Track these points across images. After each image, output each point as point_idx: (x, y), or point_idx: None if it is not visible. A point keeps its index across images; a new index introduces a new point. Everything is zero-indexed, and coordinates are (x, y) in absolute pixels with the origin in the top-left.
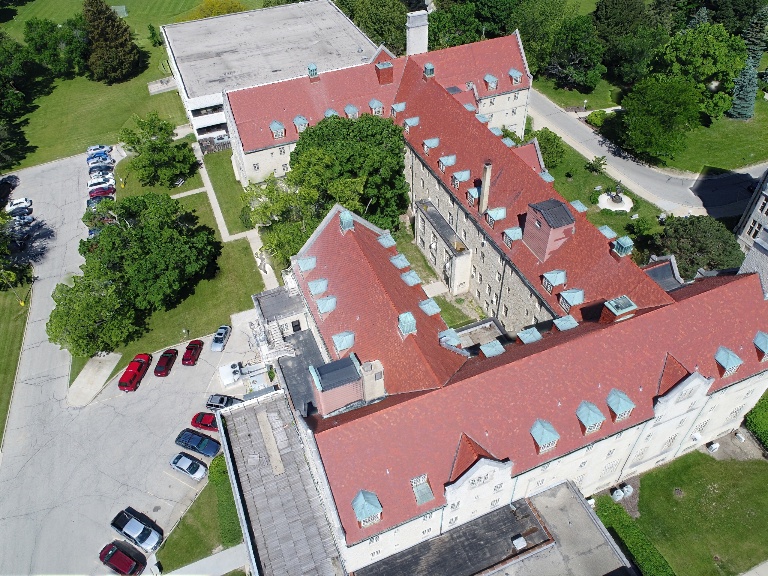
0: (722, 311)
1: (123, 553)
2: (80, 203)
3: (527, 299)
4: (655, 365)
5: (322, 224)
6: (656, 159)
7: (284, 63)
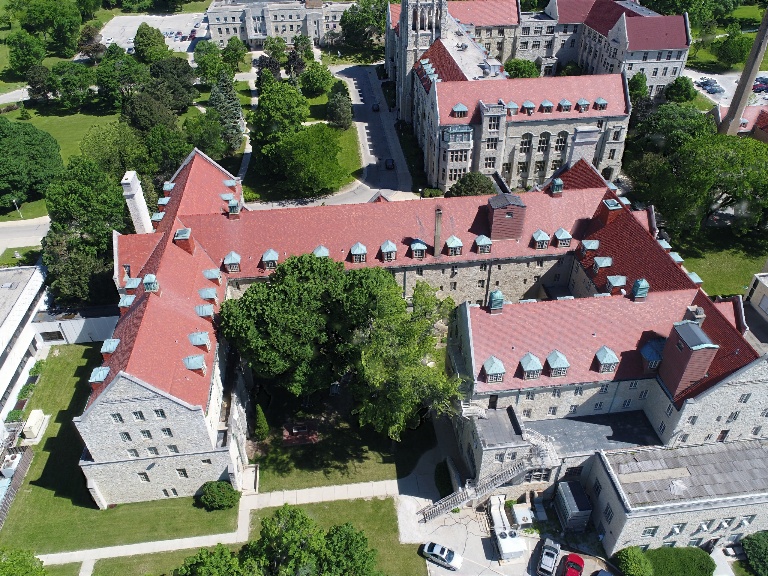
0: None
1: None
2: None
3: (524, 271)
4: None
5: (471, 329)
6: (326, 189)
7: None
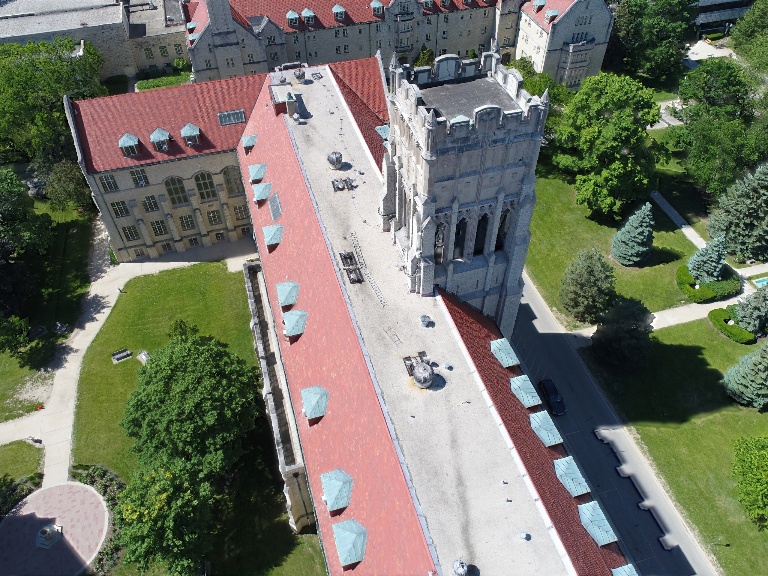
0: None
1: None
2: None
3: None
4: None
5: None
6: None
7: None
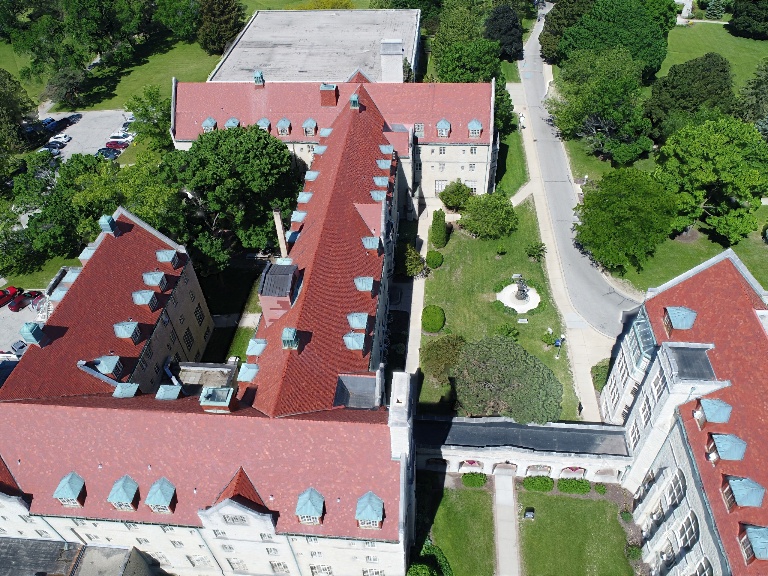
0: (327, 450)
1: None
2: (97, 150)
3: None
4: (221, 474)
5: None
6: (618, 265)
7: (316, 66)
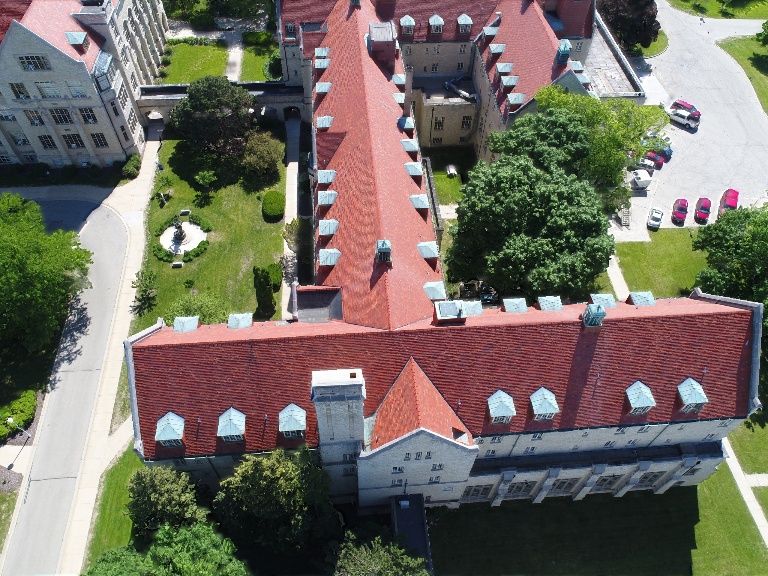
0: None
1: (686, 106)
2: None
3: None
4: None
5: None
6: None
7: None
